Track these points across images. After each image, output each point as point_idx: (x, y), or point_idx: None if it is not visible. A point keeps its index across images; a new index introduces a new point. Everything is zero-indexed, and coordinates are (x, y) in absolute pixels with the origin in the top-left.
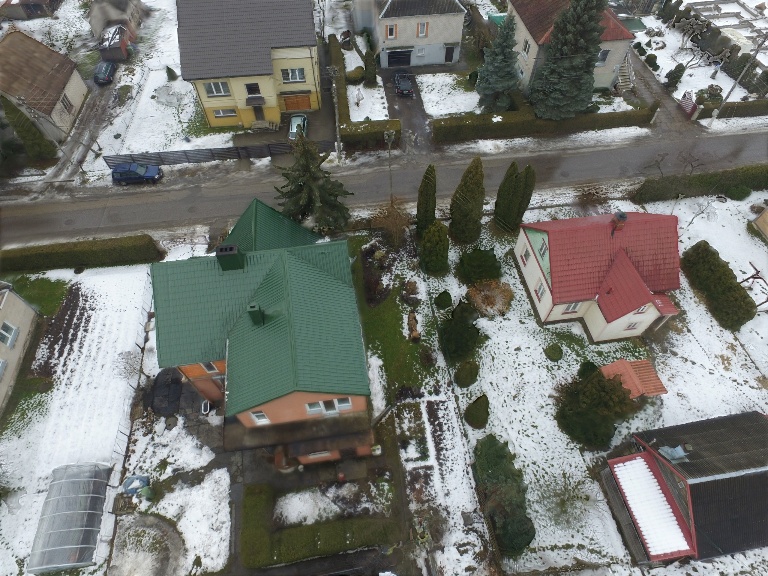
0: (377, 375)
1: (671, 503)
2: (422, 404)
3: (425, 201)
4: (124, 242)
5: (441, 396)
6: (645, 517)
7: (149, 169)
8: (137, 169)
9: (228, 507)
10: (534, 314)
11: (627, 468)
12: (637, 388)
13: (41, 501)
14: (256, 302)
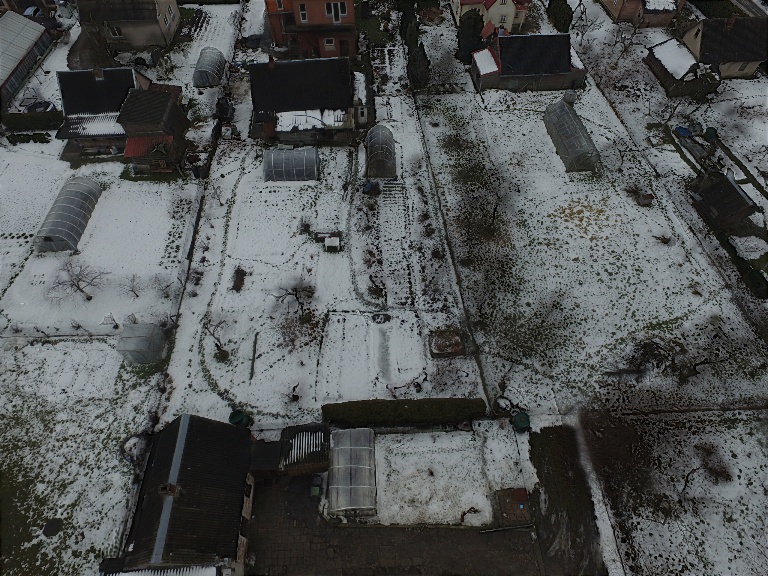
0: None
1: (495, 59)
2: (385, 49)
3: None
4: None
5: (396, 47)
6: (482, 65)
7: None
8: None
9: None
10: (454, 24)
11: (479, 53)
12: (493, 29)
13: (193, 70)
14: None
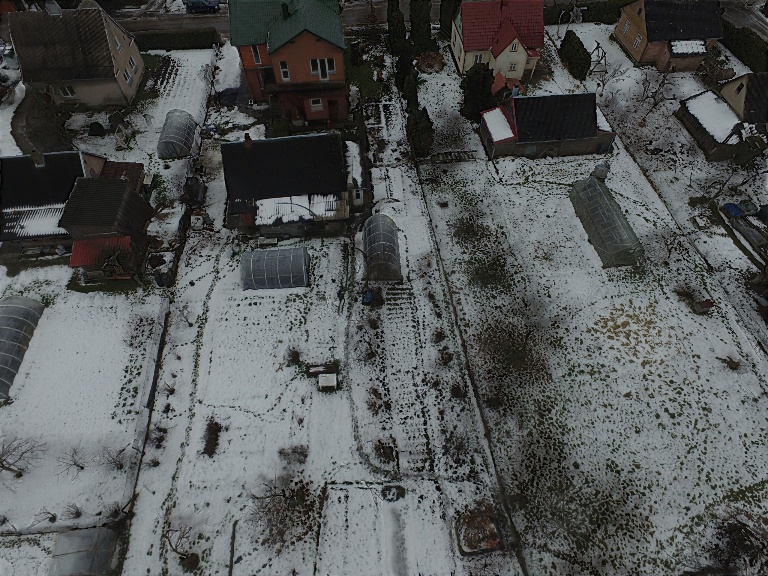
0: (355, 93)
1: (509, 122)
2: (380, 105)
3: (391, 2)
4: (199, 30)
5: (392, 102)
6: (494, 129)
7: (211, 2)
8: (204, 1)
9: (264, 137)
10: (457, 71)
11: (490, 113)
12: (504, 82)
13: (158, 135)
14: (285, 1)
